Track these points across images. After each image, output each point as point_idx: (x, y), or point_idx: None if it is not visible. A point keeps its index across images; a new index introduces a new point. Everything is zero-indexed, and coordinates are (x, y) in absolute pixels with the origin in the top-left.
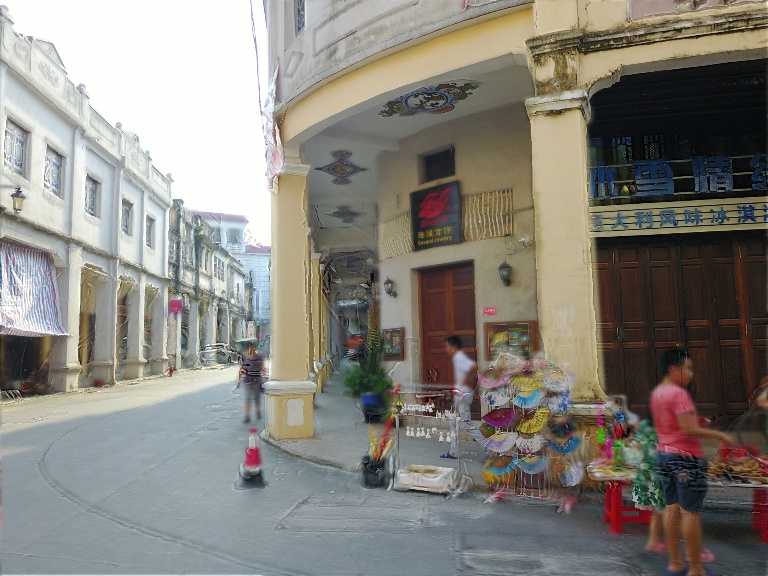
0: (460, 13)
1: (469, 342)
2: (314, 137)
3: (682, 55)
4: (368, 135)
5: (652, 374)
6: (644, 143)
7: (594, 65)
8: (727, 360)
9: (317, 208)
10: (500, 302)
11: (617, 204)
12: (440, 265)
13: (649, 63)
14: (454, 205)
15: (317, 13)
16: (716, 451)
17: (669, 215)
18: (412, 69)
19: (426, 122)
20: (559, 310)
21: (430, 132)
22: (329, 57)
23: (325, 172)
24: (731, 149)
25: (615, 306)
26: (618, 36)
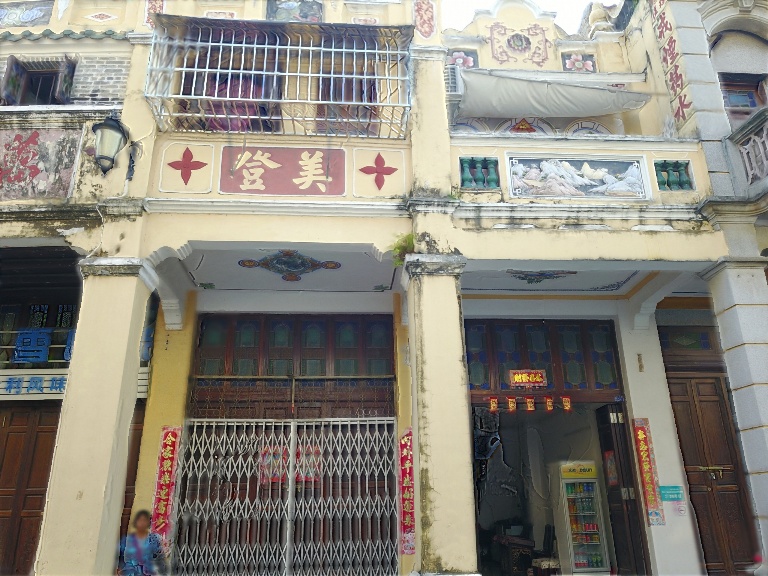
0: None
1: None
2: None
3: None
4: None
5: (14, 545)
6: (58, 312)
7: None
8: None
9: None
10: None
11: (18, 368)
12: None
13: None
14: None
15: None
16: None
17: (36, 382)
18: None
19: None
20: None
21: None
22: None
23: None
24: None
25: None
26: None
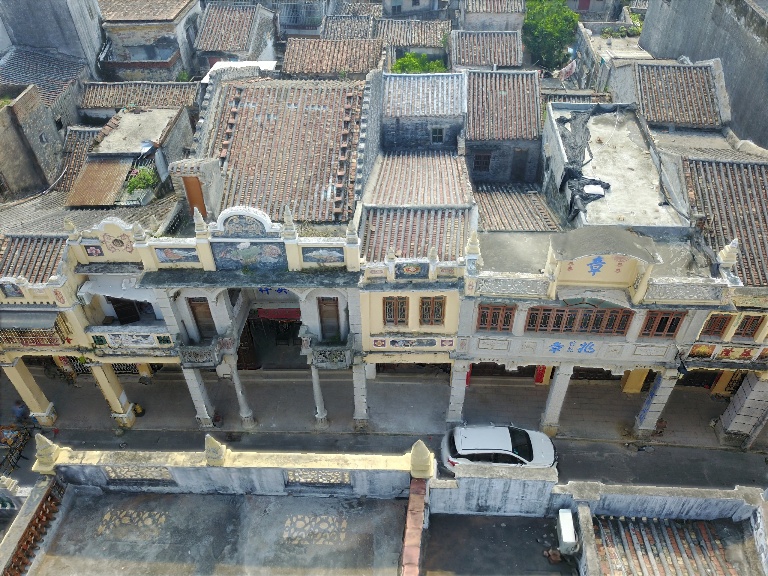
0: None
1: None
2: None
3: None
4: None
5: None
6: None
7: None
8: None
9: None
10: None
11: None
12: None
13: None
14: None
15: None
16: (39, 376)
17: None
18: None
19: None
20: None
21: None
22: None
23: None
24: None
25: None
26: None
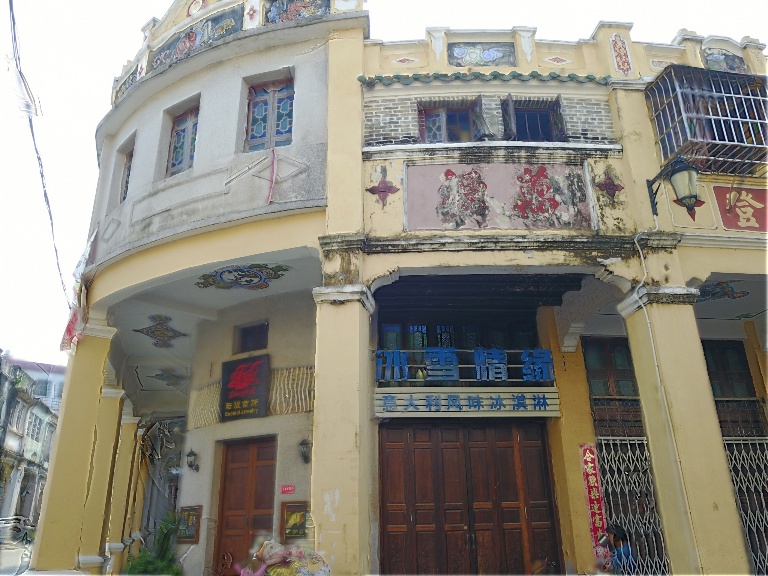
0: (263, 207)
1: (267, 523)
2: (125, 301)
3: (446, 264)
4: (186, 303)
5: (443, 559)
6: (437, 332)
7: (375, 264)
8: (510, 544)
9: (138, 369)
10: (300, 480)
11: (413, 386)
12: (245, 438)
13: (420, 268)
14: (263, 378)
15: (138, 188)
16: None
17: (455, 400)
18: (217, 249)
19: (243, 296)
20: (331, 494)
21: (247, 305)
22: (143, 228)
23: (144, 334)
24: (509, 343)
25: (409, 487)
26: (395, 243)
